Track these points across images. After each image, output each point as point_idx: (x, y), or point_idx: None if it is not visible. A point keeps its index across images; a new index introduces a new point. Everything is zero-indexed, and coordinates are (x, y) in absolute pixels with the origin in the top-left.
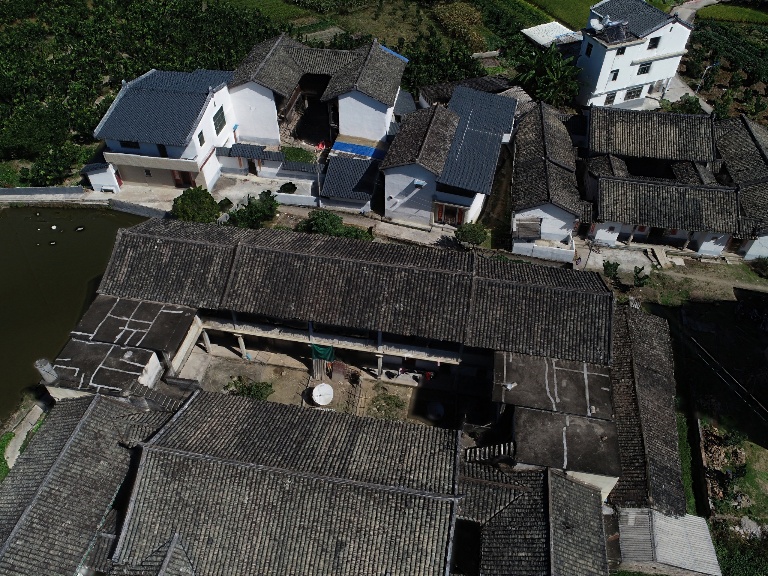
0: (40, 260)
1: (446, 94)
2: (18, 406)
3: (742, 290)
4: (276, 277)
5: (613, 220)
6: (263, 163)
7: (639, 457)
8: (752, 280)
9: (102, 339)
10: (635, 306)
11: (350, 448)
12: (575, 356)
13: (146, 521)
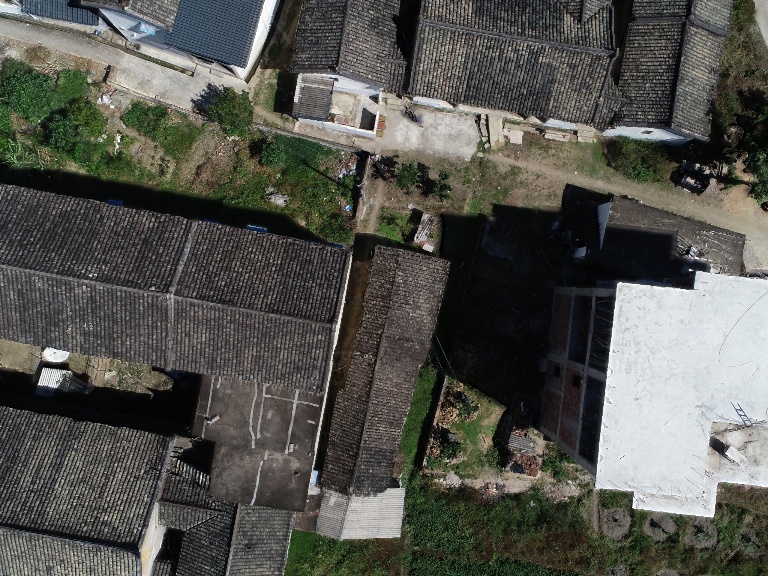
0: None
1: None
2: None
3: (575, 189)
4: None
5: (428, 95)
6: None
7: (355, 447)
8: (595, 171)
9: None
10: (422, 235)
11: (54, 477)
12: (287, 384)
13: None
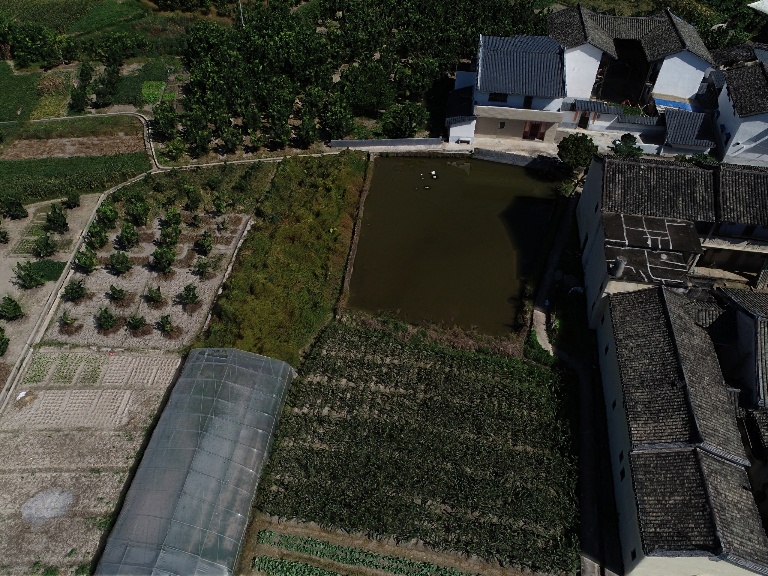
0: (437, 200)
1: (732, 58)
2: (524, 310)
3: None
4: (761, 195)
5: None
6: (598, 117)
7: None
8: None
9: (637, 244)
10: None
11: None
12: None
13: None
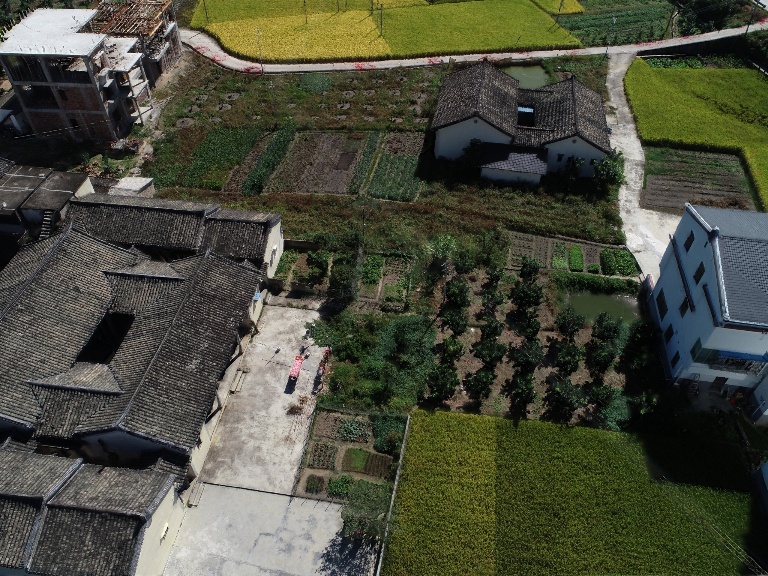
0: None
1: None
2: None
3: None
4: None
5: None
6: None
7: None
8: None
9: None
10: None
11: None
12: None
13: (8, 402)
